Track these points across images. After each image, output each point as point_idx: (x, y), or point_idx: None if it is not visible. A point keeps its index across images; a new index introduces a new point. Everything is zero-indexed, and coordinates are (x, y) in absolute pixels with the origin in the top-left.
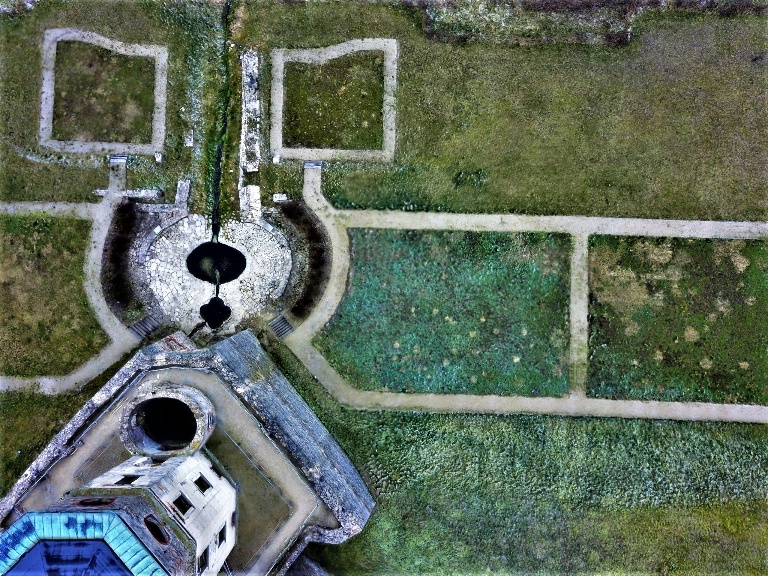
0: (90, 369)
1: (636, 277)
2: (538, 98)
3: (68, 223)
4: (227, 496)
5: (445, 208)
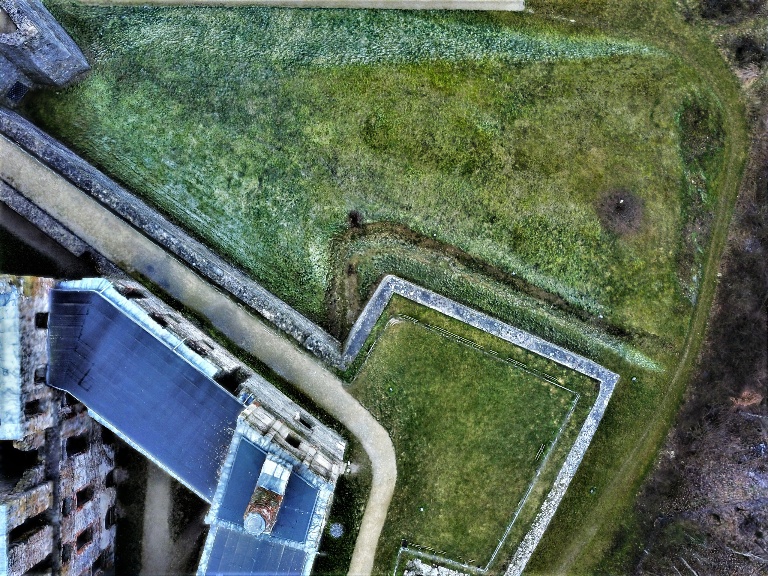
0: None
1: None
2: None
3: None
4: None
5: None
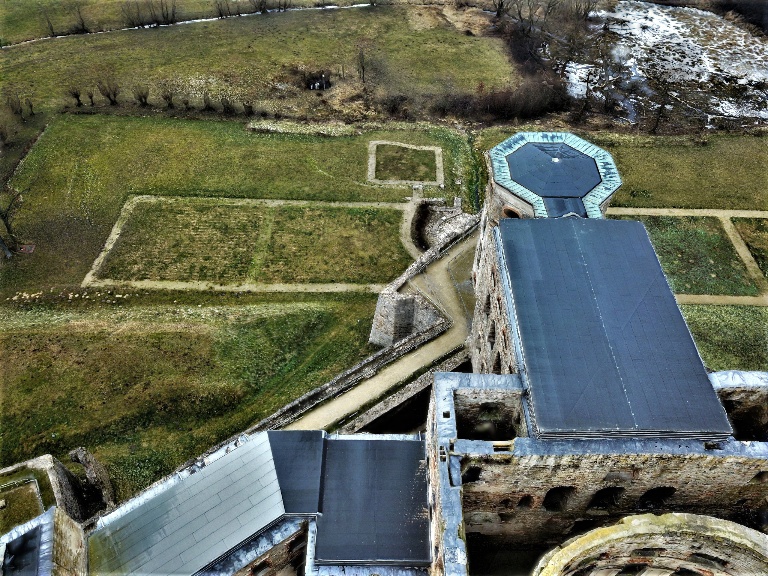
0: None
1: None
2: (667, 164)
3: (388, 211)
4: None
5: (631, 206)
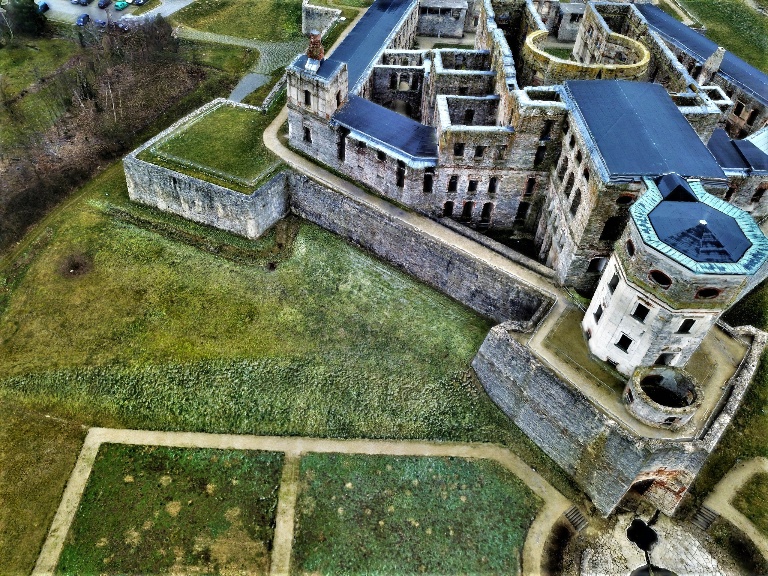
0: (737, 478)
1: (219, 569)
2: None
3: None
4: (601, 343)
5: None
